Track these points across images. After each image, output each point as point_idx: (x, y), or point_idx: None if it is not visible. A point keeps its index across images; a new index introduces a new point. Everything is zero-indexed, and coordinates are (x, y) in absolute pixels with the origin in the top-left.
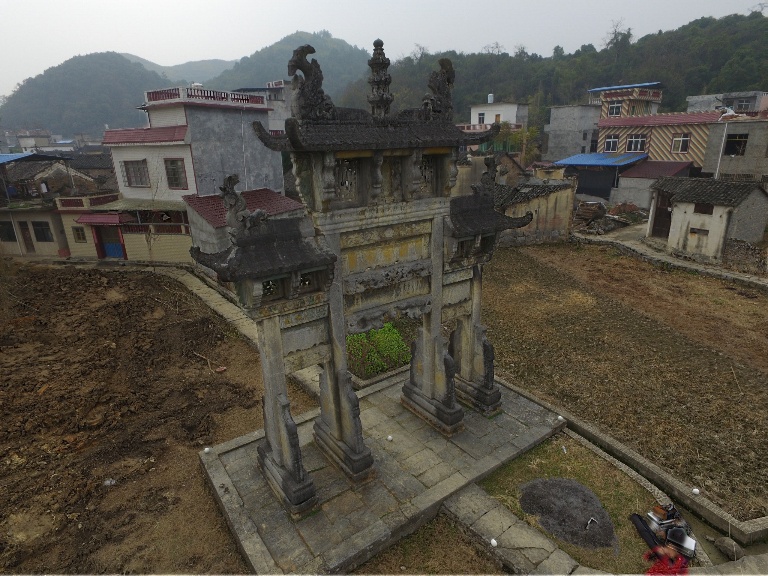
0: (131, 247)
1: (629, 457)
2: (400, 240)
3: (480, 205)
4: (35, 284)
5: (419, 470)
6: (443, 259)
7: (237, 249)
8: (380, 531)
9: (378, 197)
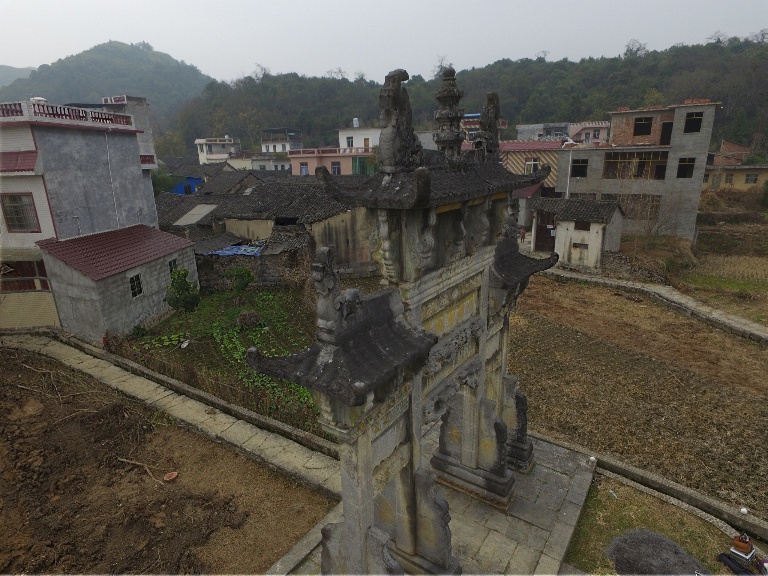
0: None
1: (668, 487)
2: (459, 299)
3: (510, 249)
4: None
5: (502, 563)
6: (488, 313)
7: (335, 350)
8: None
9: None
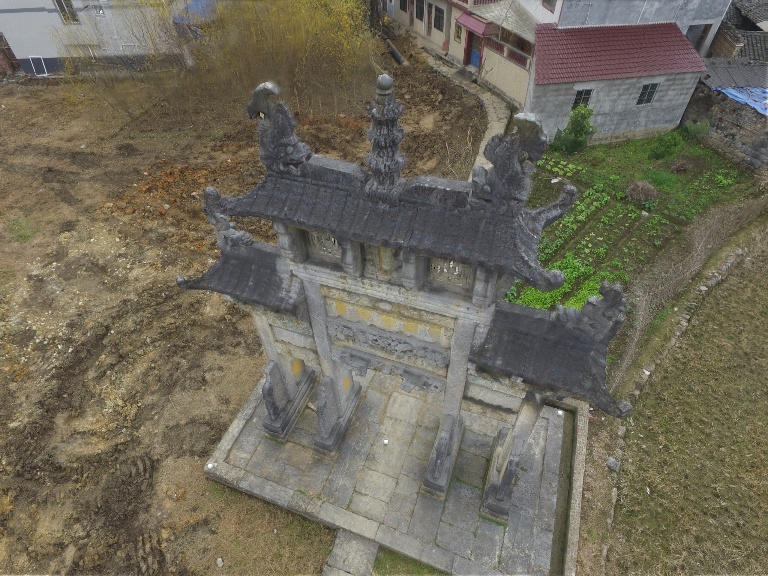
0: (486, 64)
1: None
2: None
3: (559, 337)
4: (399, 81)
5: (364, 489)
6: None
7: None
8: (283, 498)
9: (367, 269)
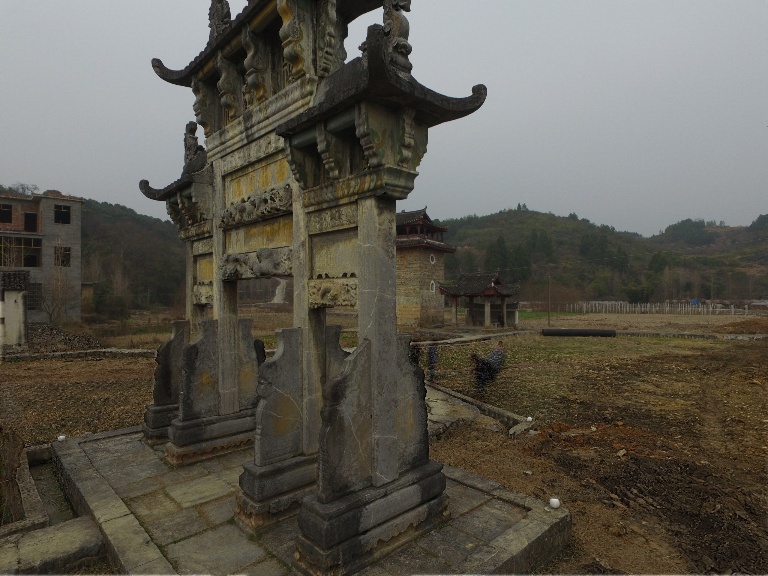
0: None
1: None
2: None
3: None
4: None
5: None
6: None
7: None
8: None
9: None
